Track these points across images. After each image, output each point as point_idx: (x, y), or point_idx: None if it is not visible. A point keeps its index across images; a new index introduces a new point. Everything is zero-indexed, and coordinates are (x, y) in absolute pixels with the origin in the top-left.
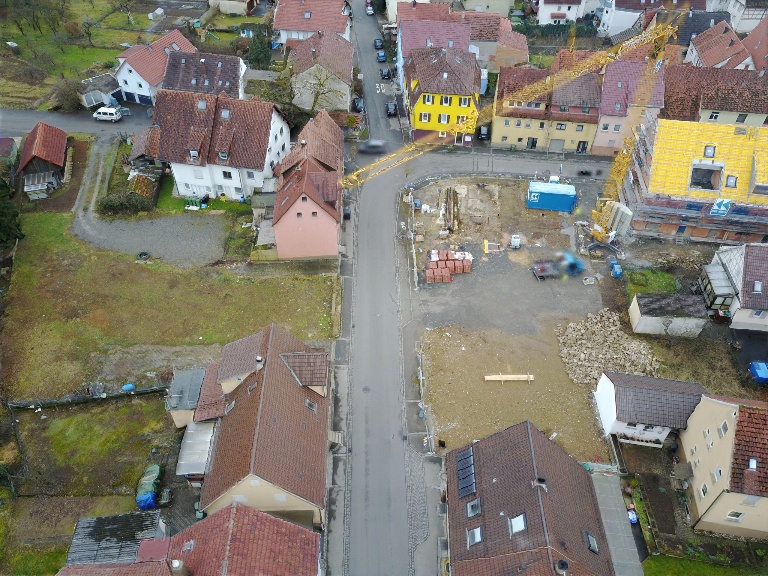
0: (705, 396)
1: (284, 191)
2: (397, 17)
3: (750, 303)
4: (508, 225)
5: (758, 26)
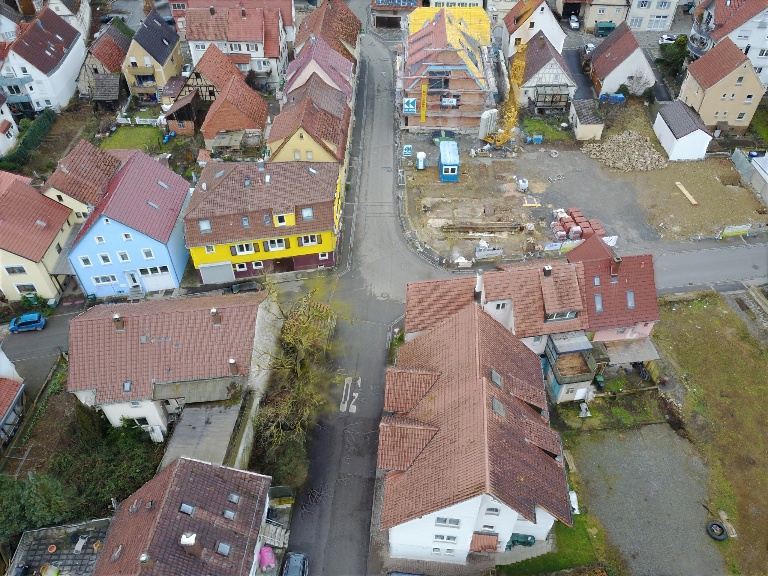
0: (710, 88)
1: (603, 309)
2: (7, 250)
3: (574, 82)
4: (490, 193)
5: (191, 2)
